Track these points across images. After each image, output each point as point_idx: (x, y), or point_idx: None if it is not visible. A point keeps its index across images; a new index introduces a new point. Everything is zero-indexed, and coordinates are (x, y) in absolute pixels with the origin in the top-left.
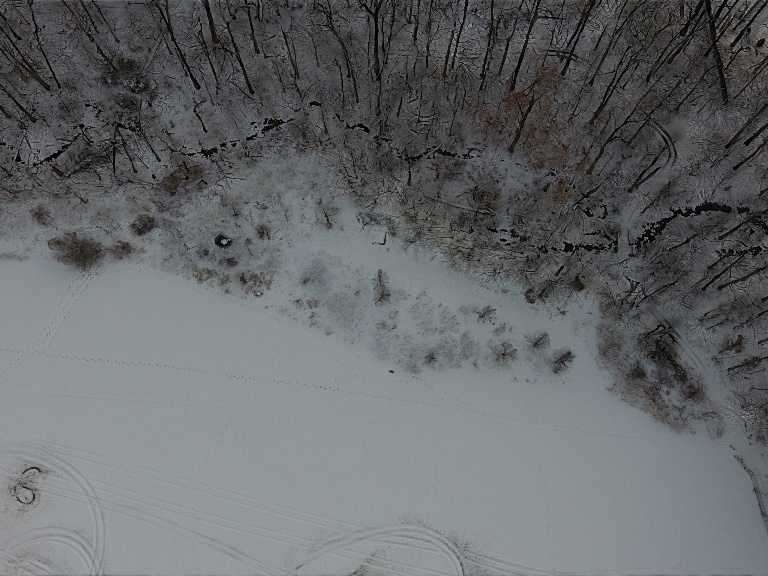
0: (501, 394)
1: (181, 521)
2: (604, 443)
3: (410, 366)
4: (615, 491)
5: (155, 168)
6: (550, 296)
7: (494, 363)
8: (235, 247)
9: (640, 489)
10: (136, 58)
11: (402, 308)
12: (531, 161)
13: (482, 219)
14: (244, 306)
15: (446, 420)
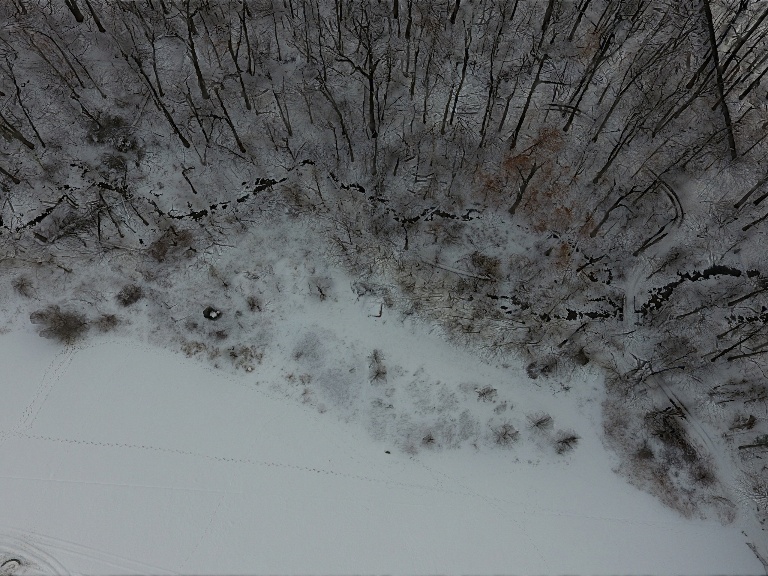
0: (502, 476)
1: None
2: (610, 530)
3: (407, 447)
4: None
5: (142, 232)
6: (553, 371)
7: (495, 444)
8: (225, 319)
9: None
10: (123, 115)
11: (399, 385)
12: (533, 224)
13: (482, 285)
14: (234, 382)
15: (445, 505)
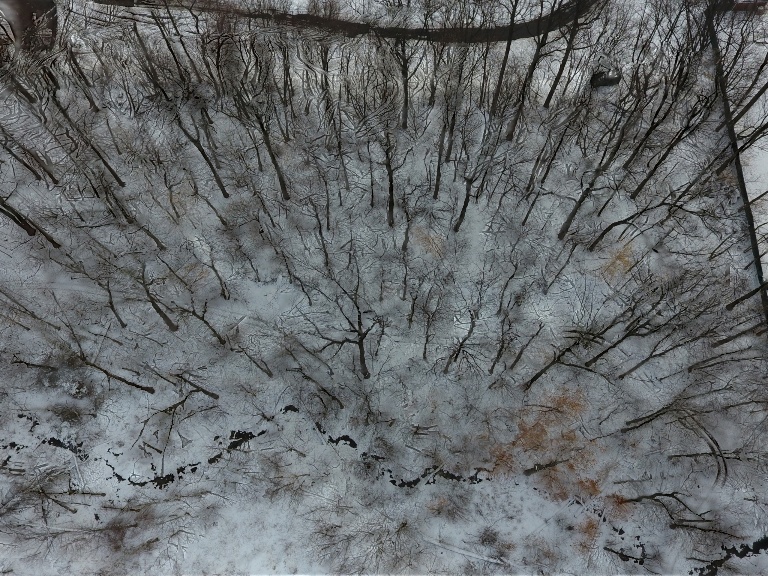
0: None
1: None
2: None
3: None
4: None
5: (98, 506)
6: None
7: None
8: None
9: None
10: None
11: None
12: (552, 494)
13: (493, 571)
14: None
15: None
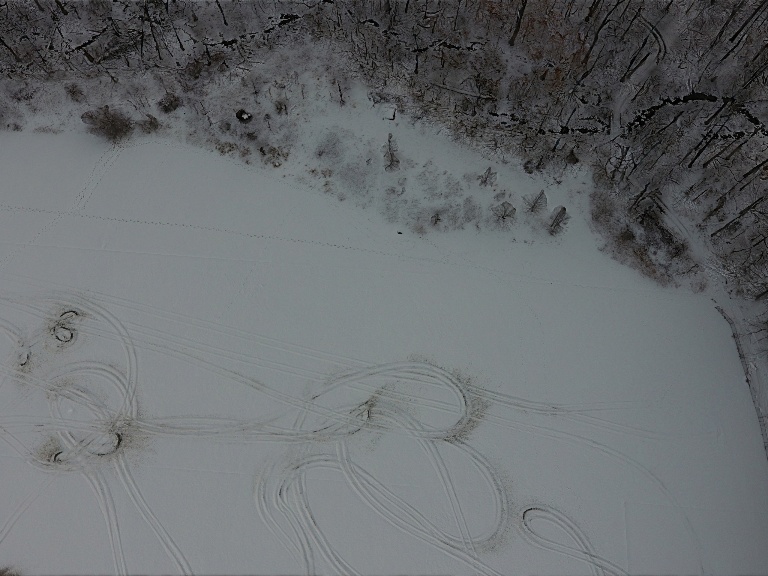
0: (501, 253)
1: (207, 357)
2: (596, 295)
3: (417, 227)
4: (605, 336)
5: (179, 56)
6: (547, 168)
7: (495, 225)
8: (255, 122)
9: (628, 334)
10: None
11: (410, 175)
12: (530, 51)
13: (484, 104)
14: (263, 175)
15: (450, 275)
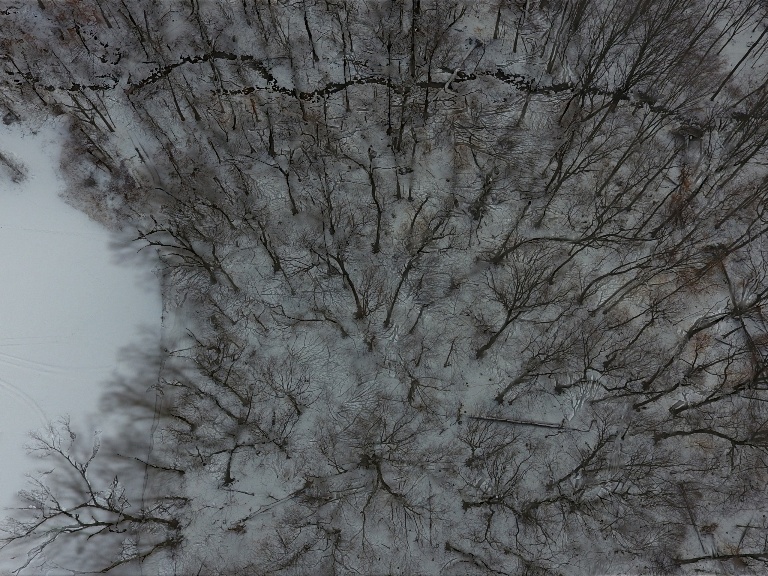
0: None
1: None
2: (42, 239)
3: None
4: (37, 276)
5: None
6: (28, 120)
7: None
8: None
9: (60, 275)
10: None
11: None
12: (52, 13)
13: (1, 63)
14: None
15: None
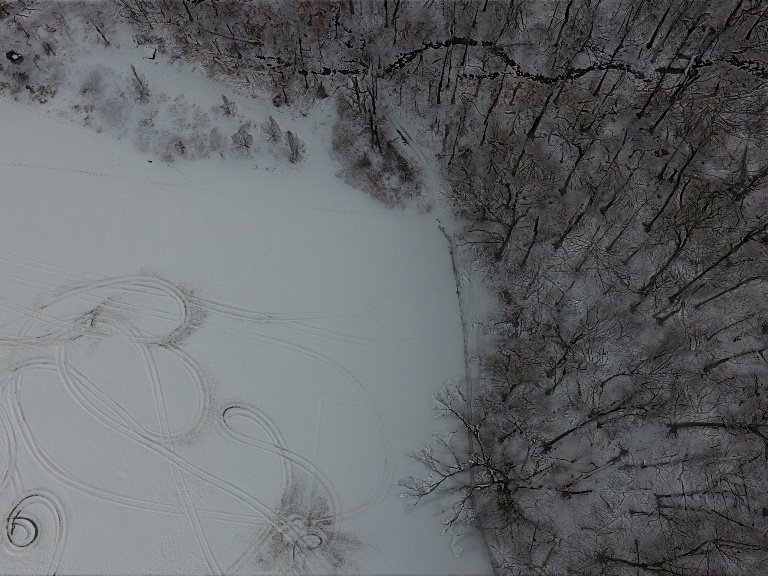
0: (243, 179)
1: None
2: (326, 217)
3: (165, 156)
4: (329, 253)
5: None
6: (296, 102)
7: (238, 153)
8: (26, 63)
9: (351, 251)
10: None
11: (162, 108)
12: None
13: (252, 48)
14: (30, 111)
15: (191, 198)
